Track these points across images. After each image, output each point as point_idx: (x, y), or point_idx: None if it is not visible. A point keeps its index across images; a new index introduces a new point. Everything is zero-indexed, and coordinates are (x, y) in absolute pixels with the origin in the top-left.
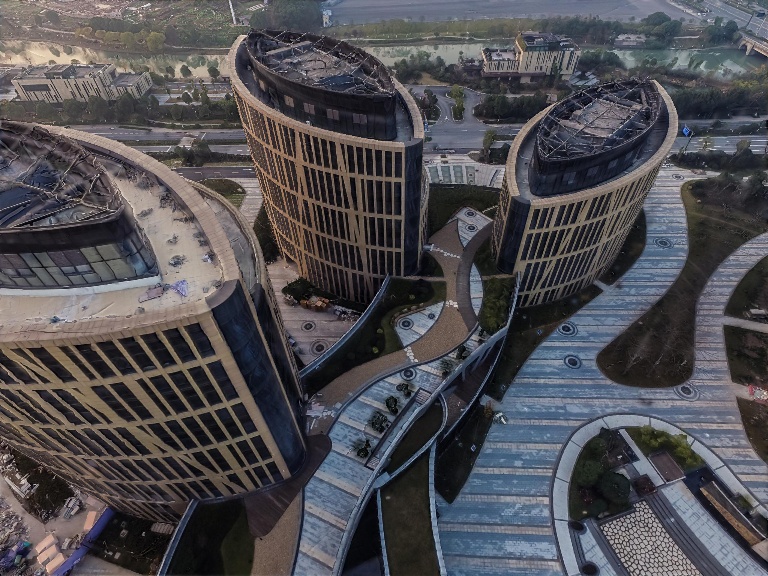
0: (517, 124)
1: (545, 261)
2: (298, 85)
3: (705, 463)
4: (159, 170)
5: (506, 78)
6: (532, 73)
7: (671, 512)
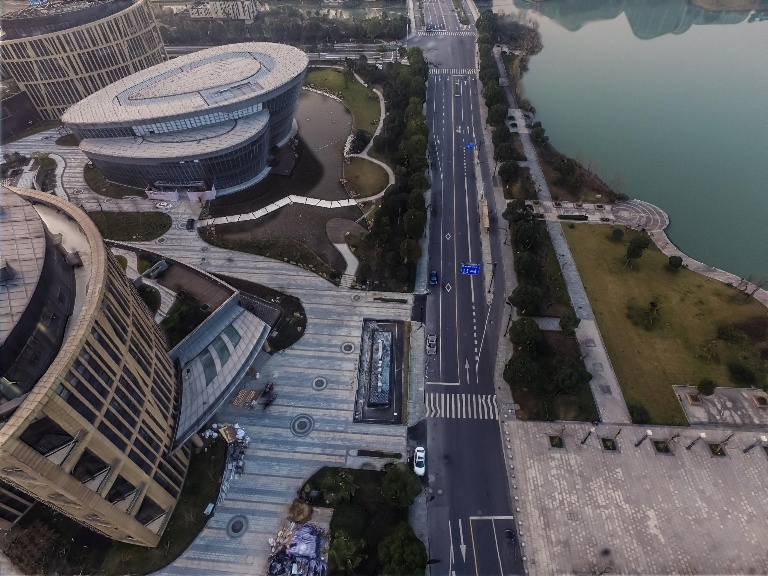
0: (179, 47)
1: (35, 84)
2: None
3: None
4: None
5: (208, 22)
6: (221, 18)
7: None
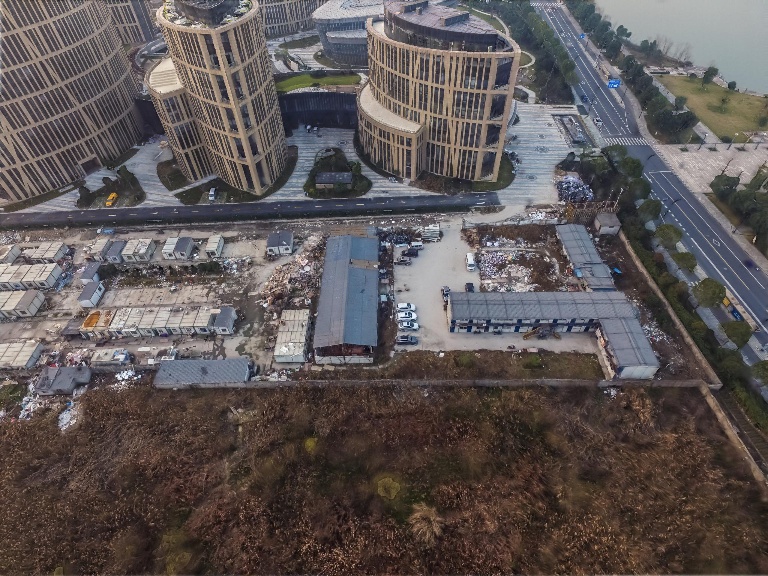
0: None
1: None
2: None
3: (294, 58)
4: None
5: None
6: None
7: (272, 64)
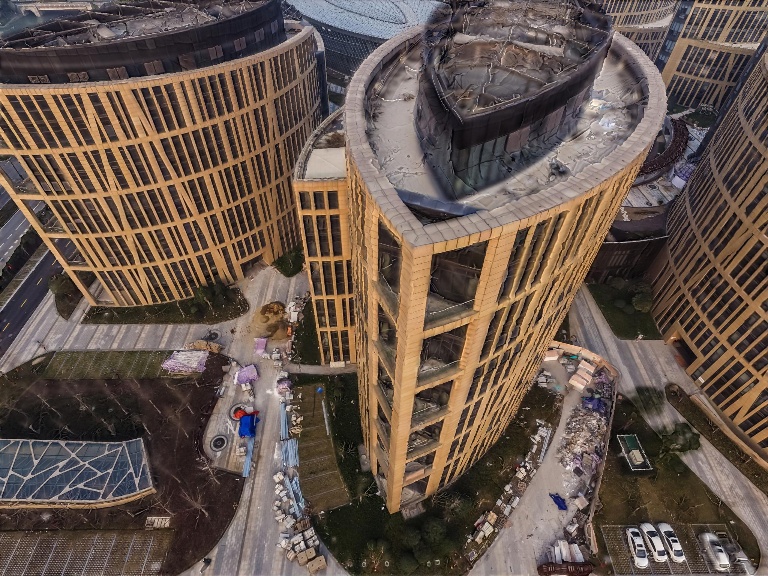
0: None
1: None
2: (227, 22)
3: None
4: (436, 22)
5: None
6: None
7: None
